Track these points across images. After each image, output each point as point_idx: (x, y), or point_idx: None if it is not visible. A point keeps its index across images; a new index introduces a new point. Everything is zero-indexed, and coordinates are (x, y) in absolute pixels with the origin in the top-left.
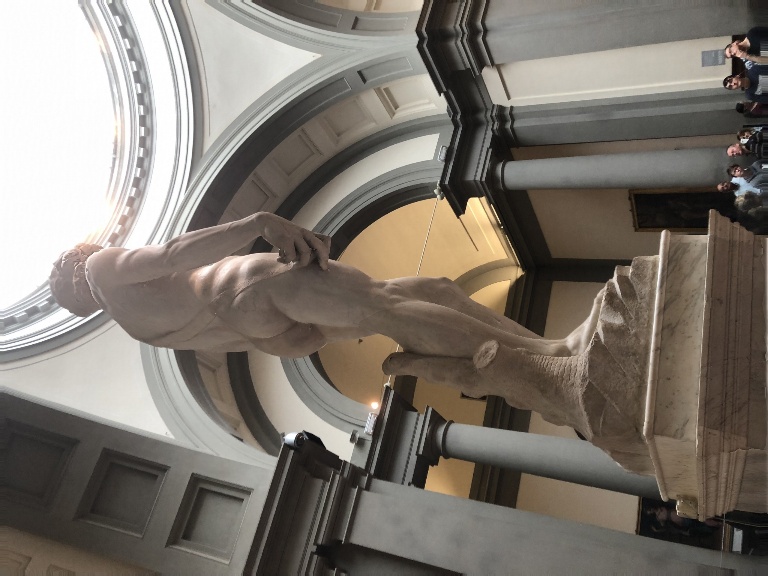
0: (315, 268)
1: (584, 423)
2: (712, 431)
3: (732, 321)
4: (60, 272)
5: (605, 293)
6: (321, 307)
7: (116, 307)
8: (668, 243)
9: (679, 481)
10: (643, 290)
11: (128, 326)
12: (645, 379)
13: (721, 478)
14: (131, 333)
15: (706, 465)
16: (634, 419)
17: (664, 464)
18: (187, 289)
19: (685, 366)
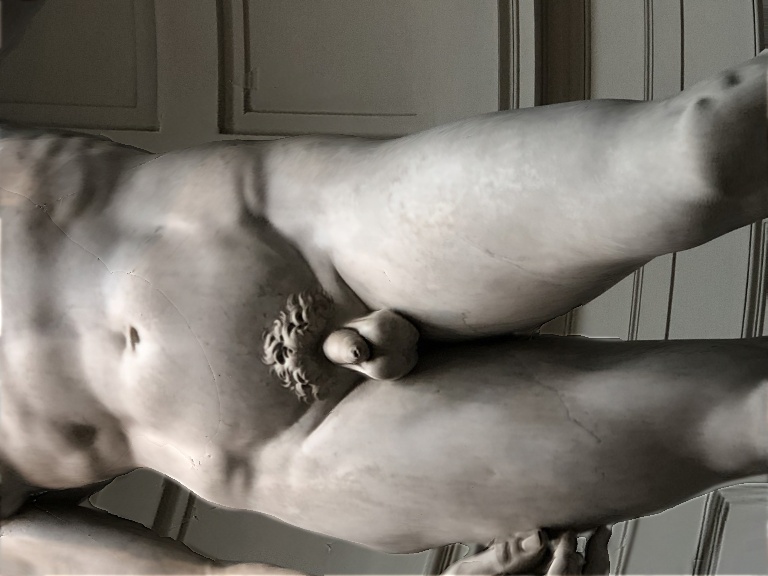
0: None
1: None
2: None
3: None
4: None
5: None
6: None
7: None
8: None
9: None
10: None
11: None
12: None
13: None
14: None
15: None
16: None
17: None
18: None
19: None
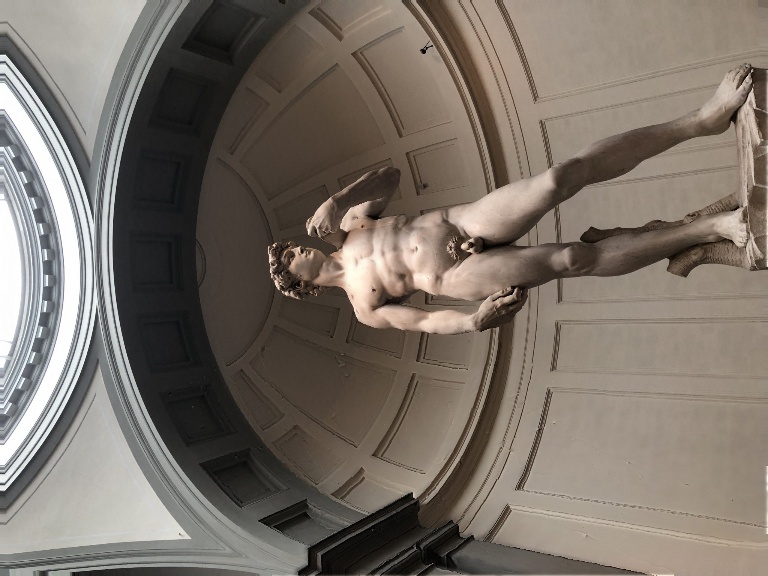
0: None
1: None
2: None
3: None
4: None
5: None
6: None
7: None
8: None
9: None
10: None
11: None
12: None
13: None
14: None
15: None
16: None
17: None
18: None
19: None
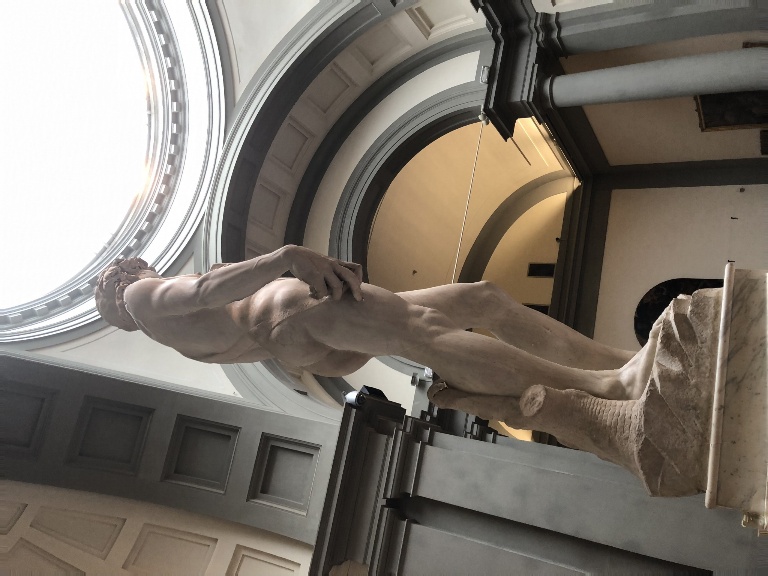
0: (349, 298)
1: (641, 479)
2: None
3: None
4: (103, 294)
5: (661, 334)
6: (359, 340)
7: (159, 336)
8: (732, 279)
9: None
10: (704, 333)
11: None
12: (707, 437)
13: None
14: (179, 350)
15: None
16: (695, 481)
17: None
18: (225, 315)
19: (752, 428)
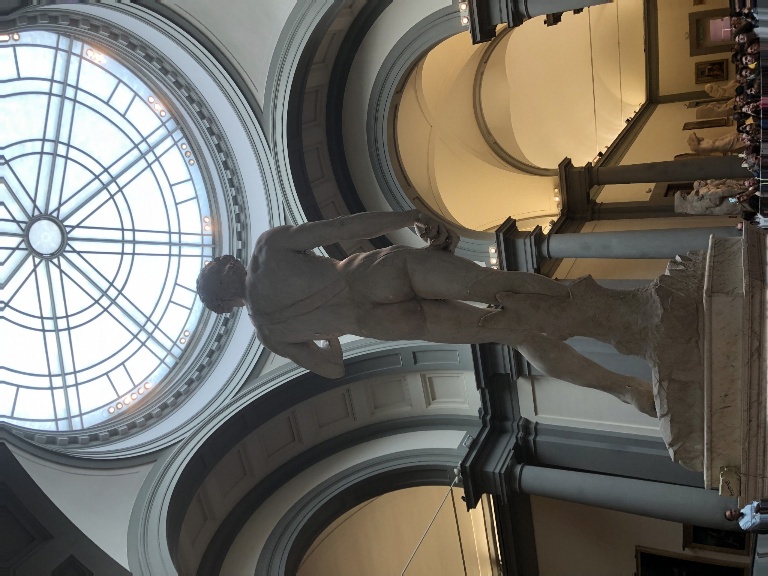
0: (445, 251)
1: (655, 308)
2: (755, 280)
3: (763, 253)
4: (217, 262)
5: None
6: (445, 270)
7: (270, 266)
8: (714, 238)
9: (725, 419)
10: (697, 257)
11: (258, 302)
12: (702, 284)
13: (762, 361)
14: (256, 309)
15: (752, 311)
16: (695, 300)
17: (715, 371)
18: (331, 266)
19: (732, 272)
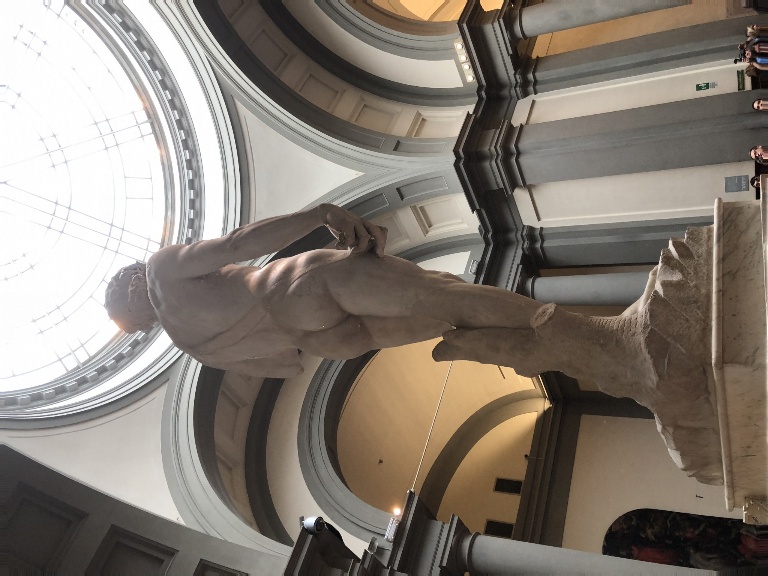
0: (371, 256)
1: (648, 369)
2: None
3: None
4: (117, 283)
5: None
6: (375, 291)
7: (171, 303)
8: (721, 208)
9: (748, 464)
10: (700, 250)
11: (176, 333)
12: (709, 322)
13: None
14: (178, 341)
15: None
16: (700, 358)
17: (732, 428)
18: (242, 286)
19: (750, 303)
